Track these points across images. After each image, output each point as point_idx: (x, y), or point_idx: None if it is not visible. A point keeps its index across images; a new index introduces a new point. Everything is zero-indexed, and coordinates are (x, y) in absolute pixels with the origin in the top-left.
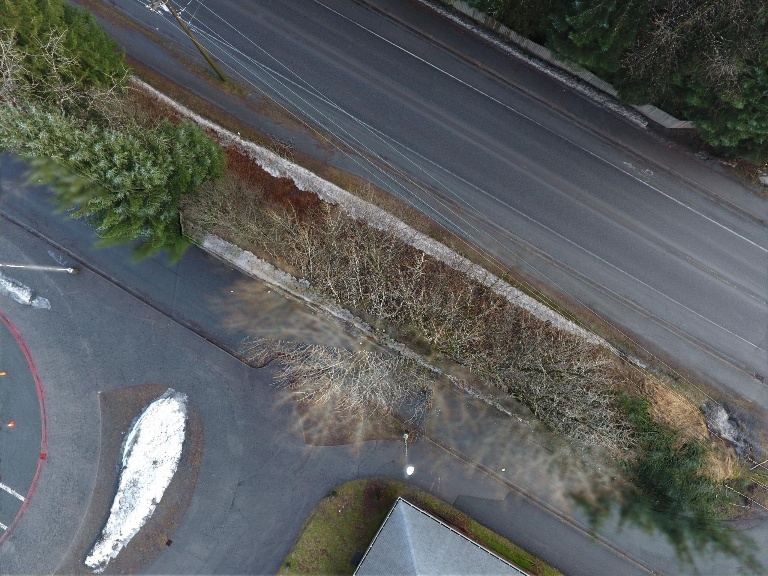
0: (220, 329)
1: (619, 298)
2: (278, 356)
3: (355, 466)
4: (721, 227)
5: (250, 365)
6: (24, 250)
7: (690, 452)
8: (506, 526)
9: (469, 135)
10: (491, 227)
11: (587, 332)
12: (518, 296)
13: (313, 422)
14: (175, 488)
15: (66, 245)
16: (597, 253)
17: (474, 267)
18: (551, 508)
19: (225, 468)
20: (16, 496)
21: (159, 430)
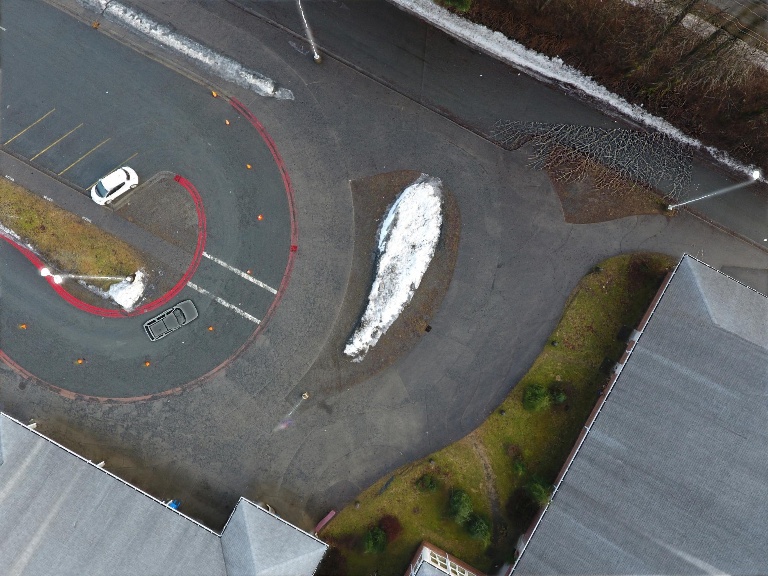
0: (471, 113)
1: None
2: (532, 138)
3: (617, 242)
4: None
5: (504, 148)
6: (264, 41)
7: None
8: None
9: None
10: None
11: None
12: None
13: (572, 201)
14: (433, 273)
15: (306, 35)
16: None
17: (731, 38)
18: None
19: (484, 251)
20: (268, 289)
21: (416, 214)
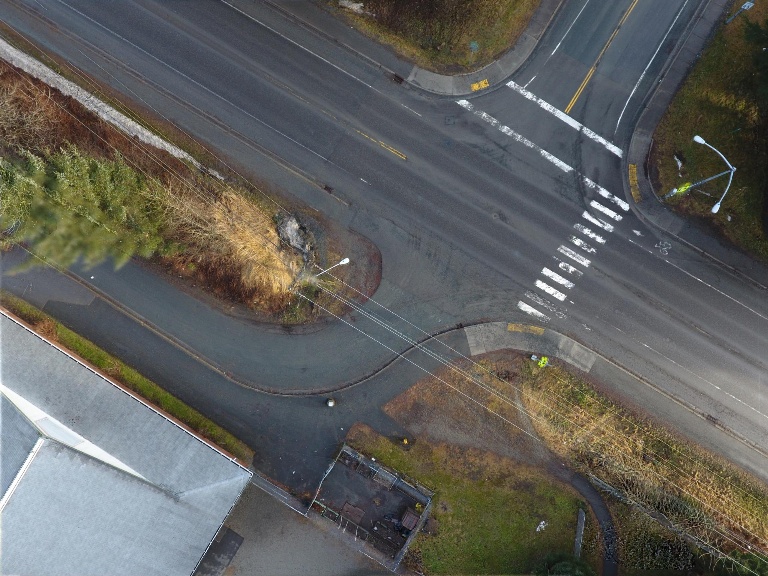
0: None
1: (202, 114)
2: None
3: None
4: (298, 46)
5: None
6: None
7: (250, 254)
8: (90, 329)
9: None
10: (87, 47)
11: (172, 146)
12: (107, 111)
13: None
14: None
15: None
16: (183, 71)
17: (68, 84)
18: (134, 313)
19: None
20: None
21: None
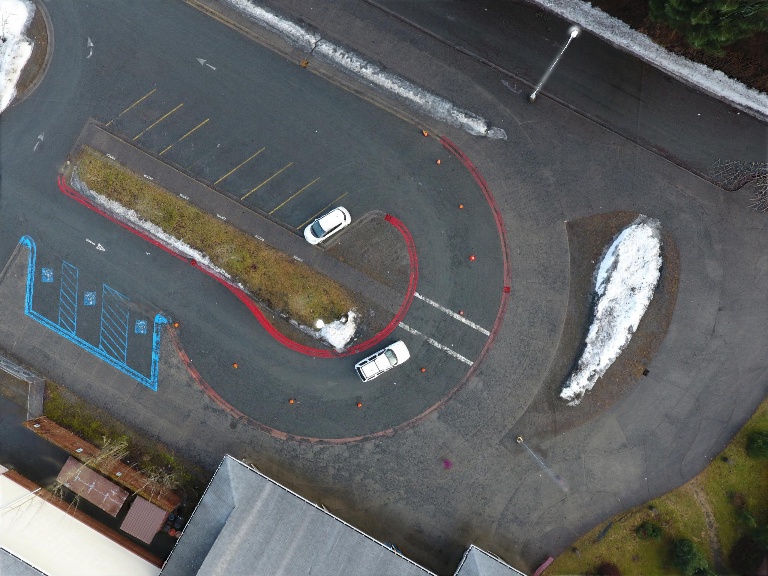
0: (689, 153)
1: None
2: (753, 178)
3: None
4: None
5: (724, 188)
6: (476, 80)
7: None
8: None
9: None
10: None
11: None
12: None
13: None
14: (651, 316)
15: (519, 74)
16: None
17: None
18: None
19: (704, 294)
20: (481, 331)
21: (636, 256)
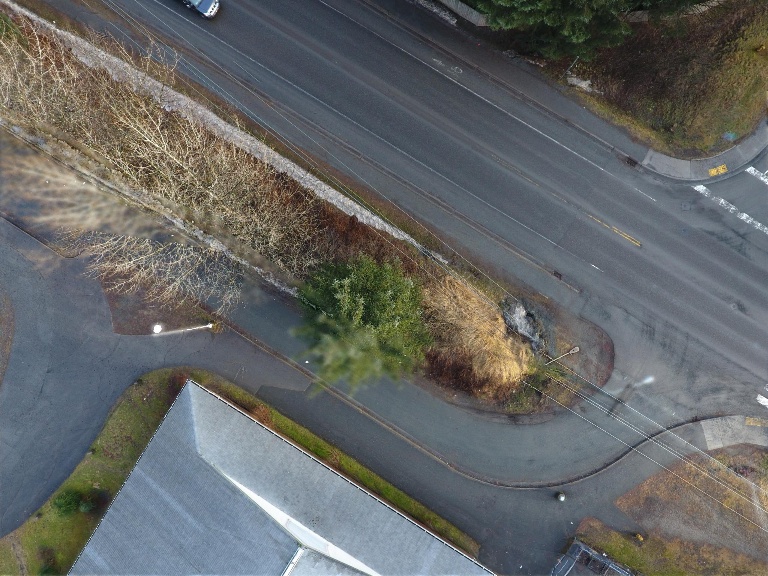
0: (35, 219)
1: (424, 194)
2: (91, 246)
3: (161, 355)
4: (526, 126)
5: (63, 255)
6: None
7: (482, 344)
8: (306, 416)
9: (283, 29)
10: (302, 122)
11: (392, 227)
12: (325, 190)
13: (122, 312)
14: None
15: None
16: (404, 149)
17: (283, 160)
18: (352, 400)
19: (35, 355)
20: None
21: None
